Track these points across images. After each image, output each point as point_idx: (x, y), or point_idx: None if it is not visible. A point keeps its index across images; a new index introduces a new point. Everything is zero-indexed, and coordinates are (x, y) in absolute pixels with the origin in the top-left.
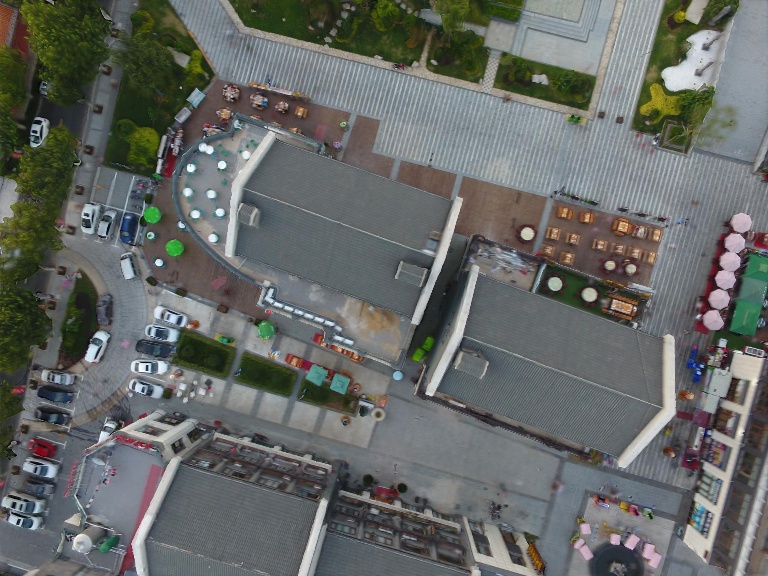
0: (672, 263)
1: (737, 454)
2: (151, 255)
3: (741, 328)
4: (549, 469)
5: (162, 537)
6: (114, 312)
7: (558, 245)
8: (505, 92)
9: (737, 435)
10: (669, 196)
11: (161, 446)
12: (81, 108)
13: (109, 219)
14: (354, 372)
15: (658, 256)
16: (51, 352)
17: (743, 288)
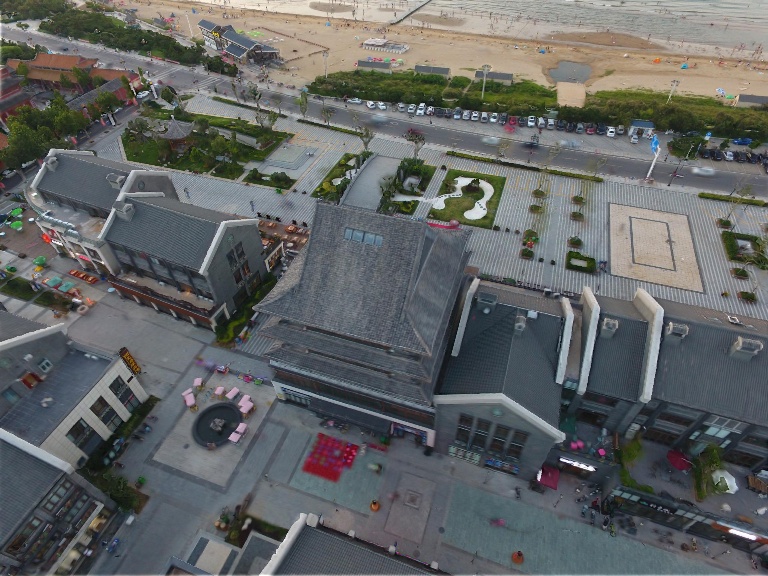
0: None
1: None
2: None
3: None
4: (193, 351)
5: None
6: None
7: None
8: None
9: None
10: None
11: None
12: (19, 182)
13: None
14: (84, 290)
15: None
16: None
17: None
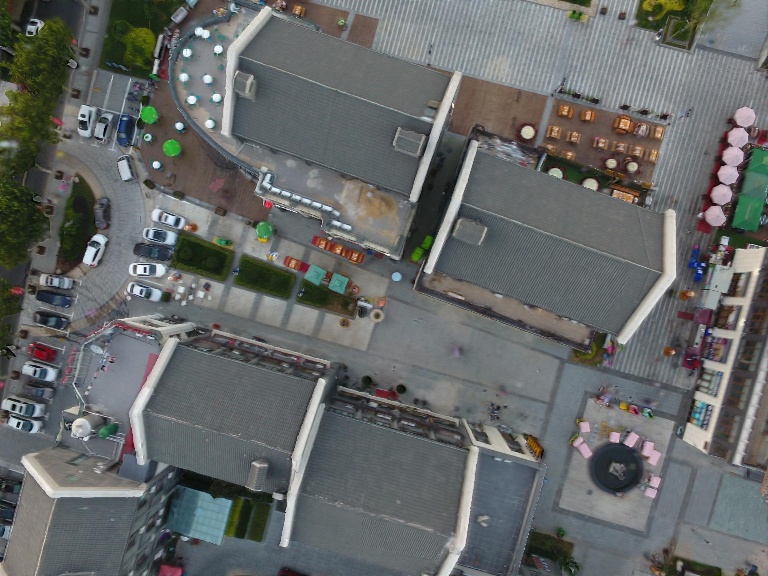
0: (674, 162)
1: (738, 344)
2: (148, 158)
3: (743, 223)
4: (548, 370)
5: (160, 409)
6: (112, 216)
7: (559, 144)
8: None
9: (738, 326)
10: (672, 94)
11: (159, 334)
12: (77, 10)
13: (106, 121)
14: (353, 274)
15: (660, 155)
16: (49, 257)
17: (746, 182)
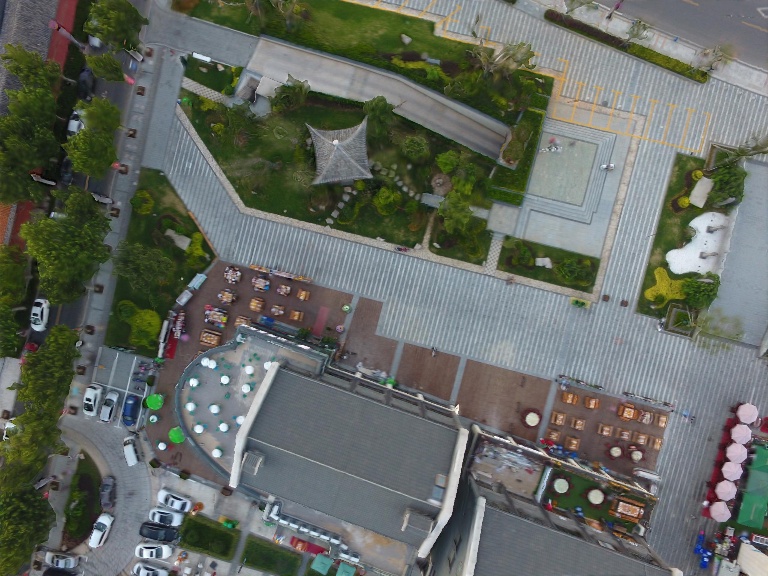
0: (678, 447)
1: None
2: (154, 437)
3: (748, 522)
4: None
5: None
6: (117, 493)
7: (563, 429)
8: (508, 274)
9: None
10: (675, 380)
11: None
12: None
13: (111, 403)
14: None
15: (664, 440)
16: (55, 533)
17: (750, 481)
